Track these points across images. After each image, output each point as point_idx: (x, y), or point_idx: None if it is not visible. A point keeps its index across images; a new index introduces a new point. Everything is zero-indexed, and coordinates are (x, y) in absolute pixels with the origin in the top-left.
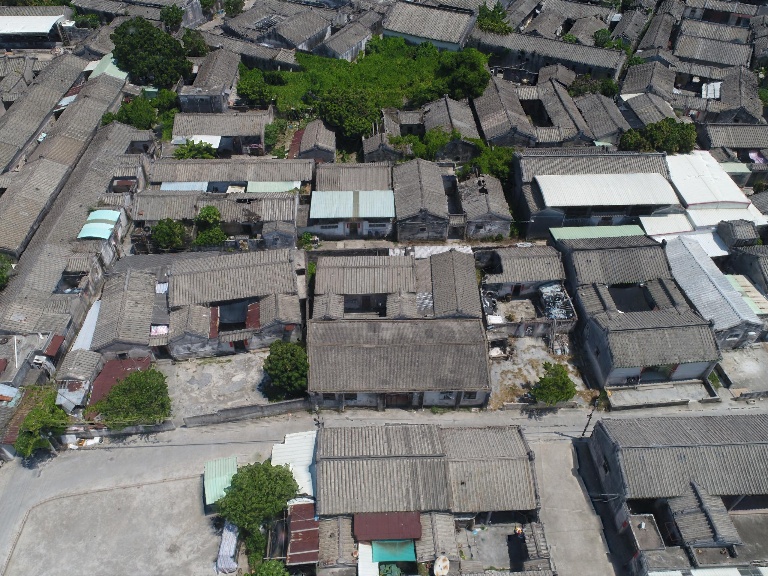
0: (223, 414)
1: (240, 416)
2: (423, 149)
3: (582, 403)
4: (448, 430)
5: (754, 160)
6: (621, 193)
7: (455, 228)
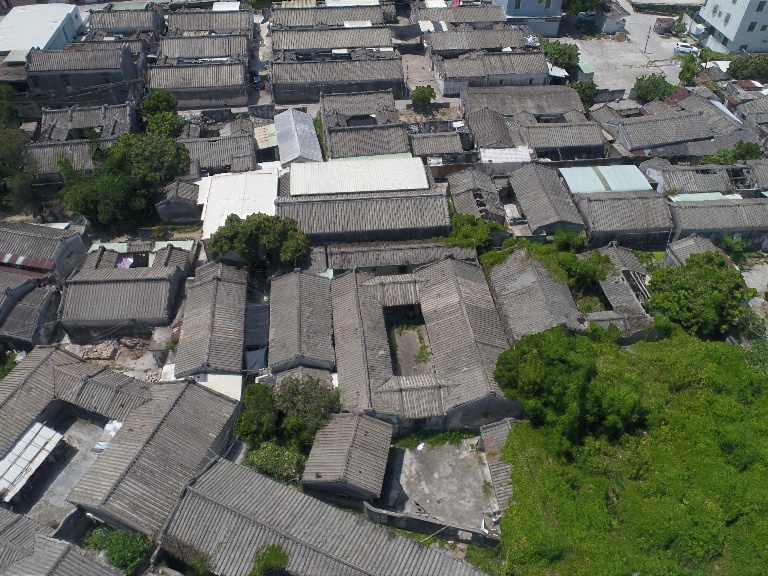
0: (606, 93)
1: (597, 98)
2: (561, 255)
3: (402, 111)
4: (482, 76)
5: (130, 265)
6: (345, 167)
7: (499, 191)
